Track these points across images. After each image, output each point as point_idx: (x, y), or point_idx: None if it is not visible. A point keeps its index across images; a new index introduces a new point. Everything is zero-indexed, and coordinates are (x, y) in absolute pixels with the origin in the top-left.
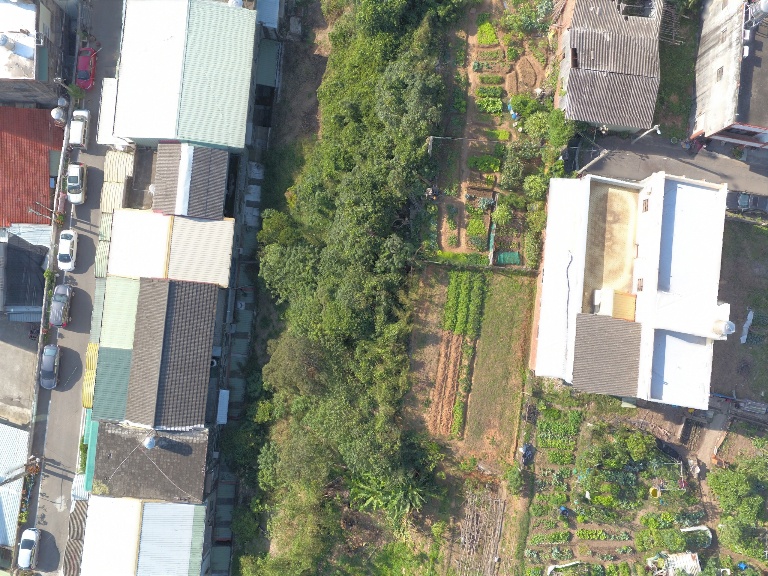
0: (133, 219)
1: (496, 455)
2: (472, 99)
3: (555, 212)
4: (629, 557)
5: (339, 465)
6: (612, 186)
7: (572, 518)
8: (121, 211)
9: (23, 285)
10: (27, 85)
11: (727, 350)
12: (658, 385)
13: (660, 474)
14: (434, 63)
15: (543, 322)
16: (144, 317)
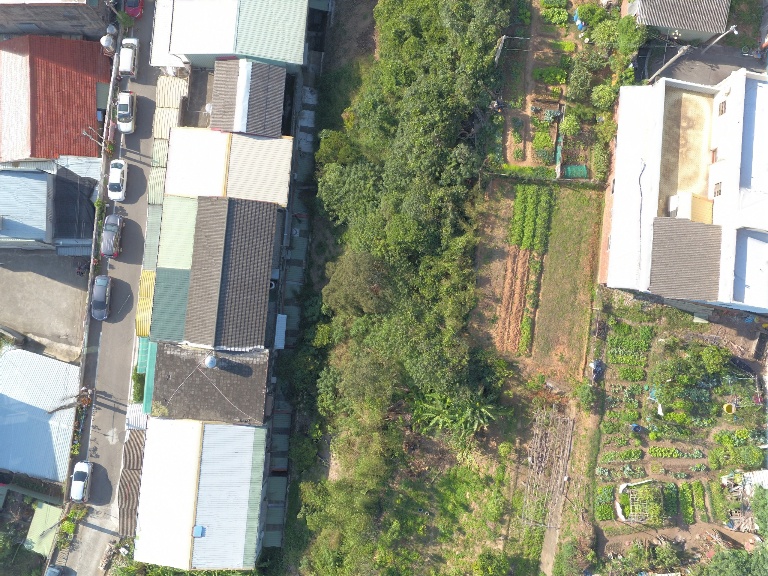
0: (190, 137)
1: (565, 372)
2: (537, 10)
3: (626, 120)
4: (703, 475)
5: (401, 388)
6: (686, 91)
7: (644, 435)
8: (178, 129)
9: (72, 218)
10: (77, 11)
11: None
12: (740, 288)
13: (734, 390)
14: None
15: (615, 232)
16: (203, 236)
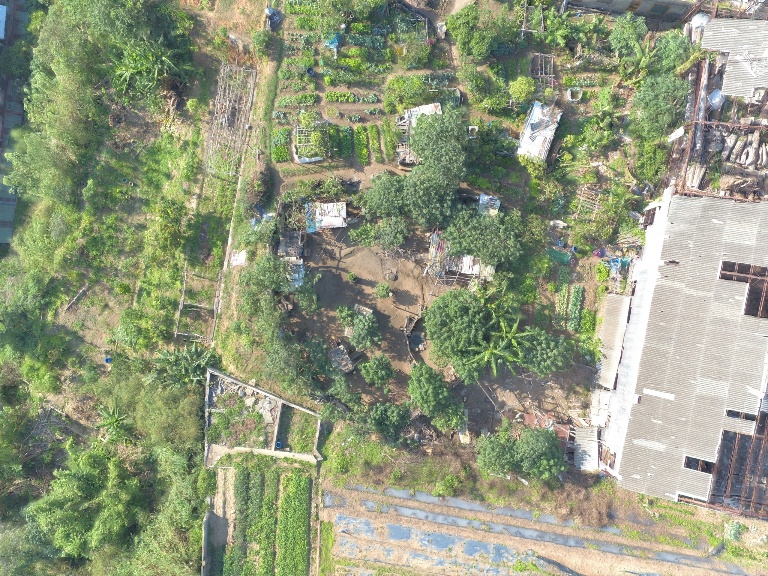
0: None
1: (247, 25)
2: None
3: None
4: (379, 120)
5: (106, 63)
6: None
7: (321, 82)
8: None
9: None
10: None
11: None
12: None
13: (409, 38)
14: None
15: None
16: None
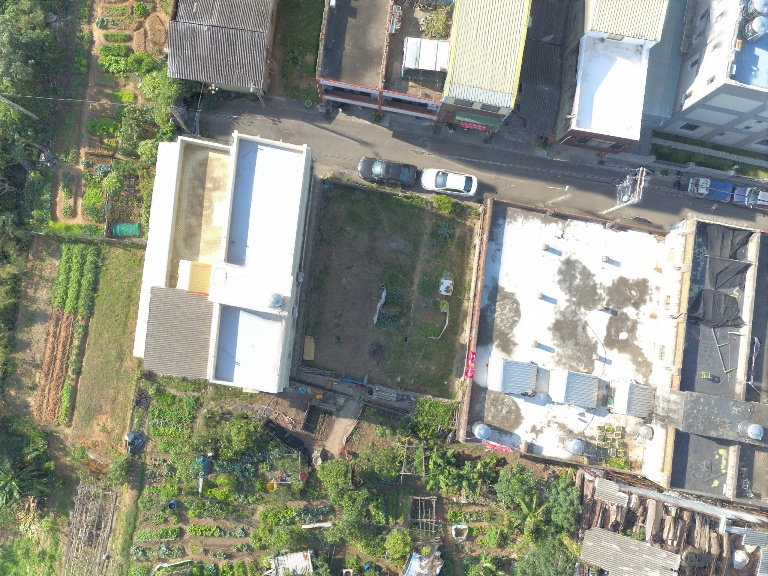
0: None
1: (107, 443)
2: (95, 58)
3: (160, 179)
4: (247, 556)
5: None
6: (213, 150)
7: (185, 512)
8: None
9: None
10: None
11: (359, 331)
12: (229, 366)
13: (282, 465)
14: (42, 17)
15: (143, 298)
16: None
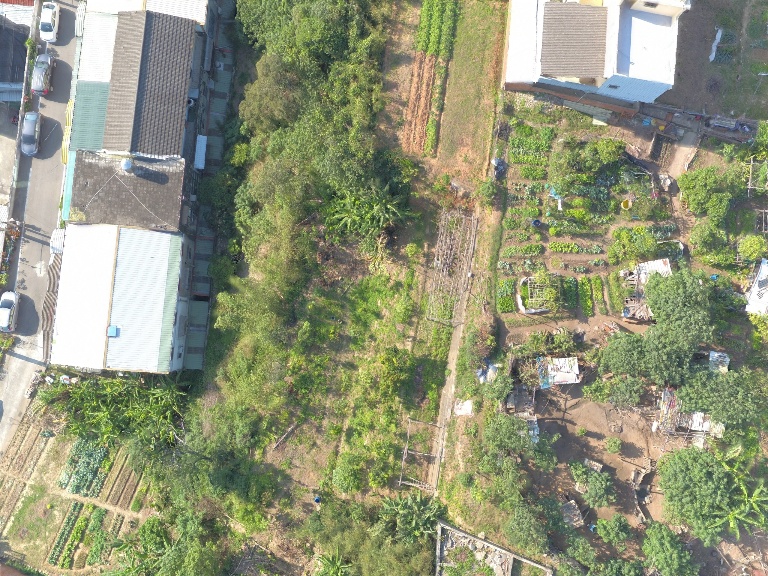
0: None
1: (469, 172)
2: None
3: None
4: (601, 270)
5: (315, 200)
6: None
7: (544, 232)
8: None
9: (6, 63)
10: None
11: (696, 69)
12: (624, 65)
13: (631, 189)
14: None
15: (513, 31)
16: (122, 48)
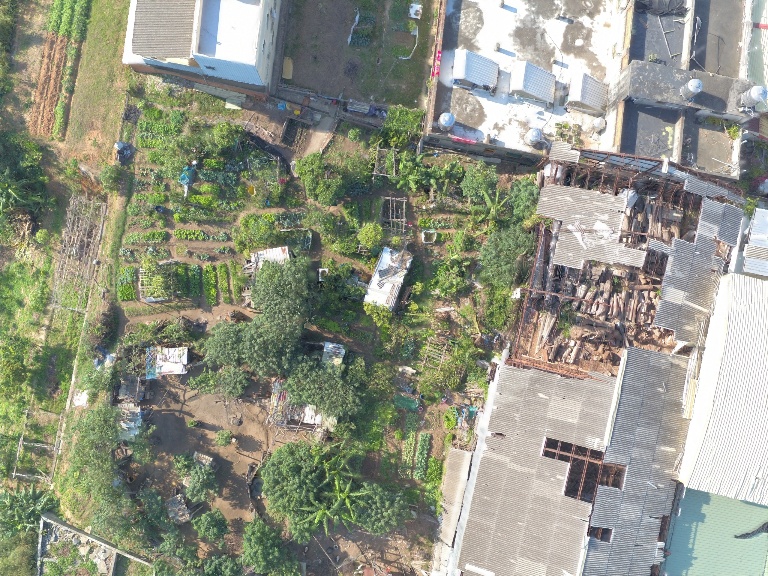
0: None
1: (98, 157)
2: None
3: None
4: (229, 258)
5: None
6: None
7: (171, 218)
8: None
9: None
10: None
11: (335, 52)
12: (211, 45)
13: (263, 175)
14: None
15: (132, 10)
16: None
